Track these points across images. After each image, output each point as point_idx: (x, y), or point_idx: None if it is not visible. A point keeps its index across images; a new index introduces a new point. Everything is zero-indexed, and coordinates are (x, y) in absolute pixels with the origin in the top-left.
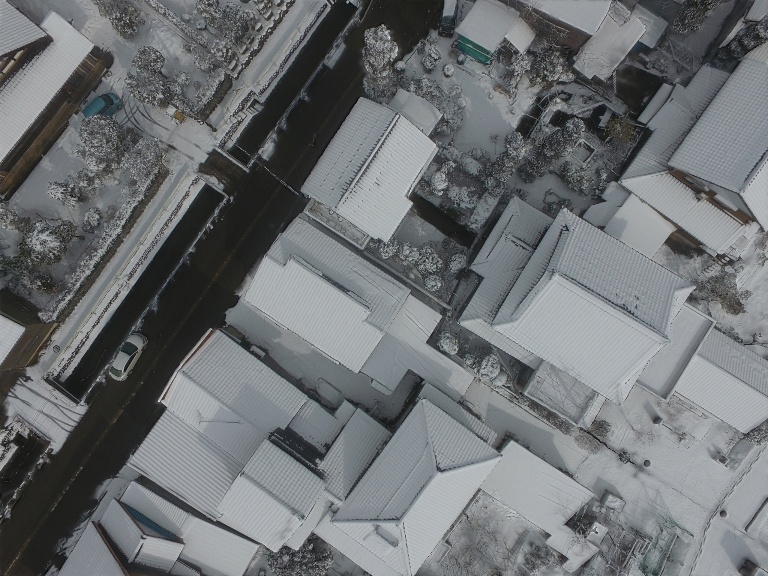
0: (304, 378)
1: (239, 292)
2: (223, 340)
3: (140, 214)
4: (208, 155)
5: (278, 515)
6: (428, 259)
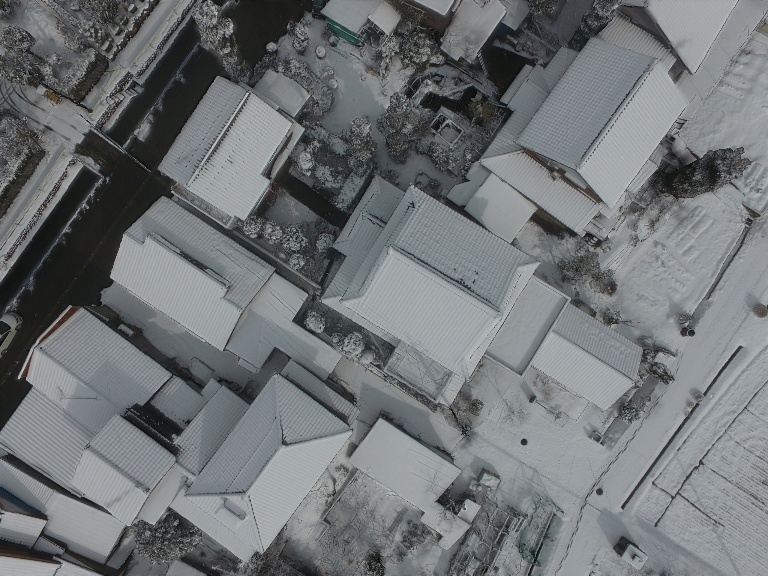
0: (178, 357)
1: None
2: (87, 318)
3: (16, 194)
4: (84, 136)
5: (125, 488)
6: (292, 238)
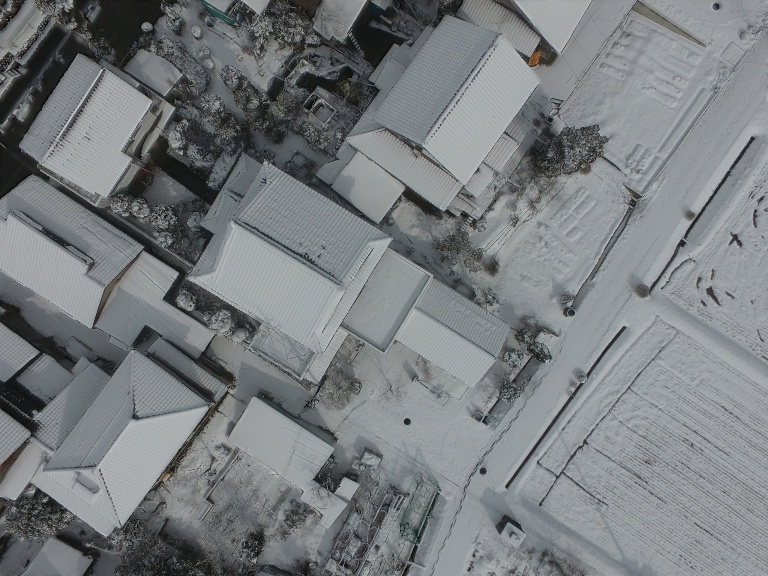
0: (55, 336)
1: None
2: None
3: None
4: None
5: None
6: (160, 216)
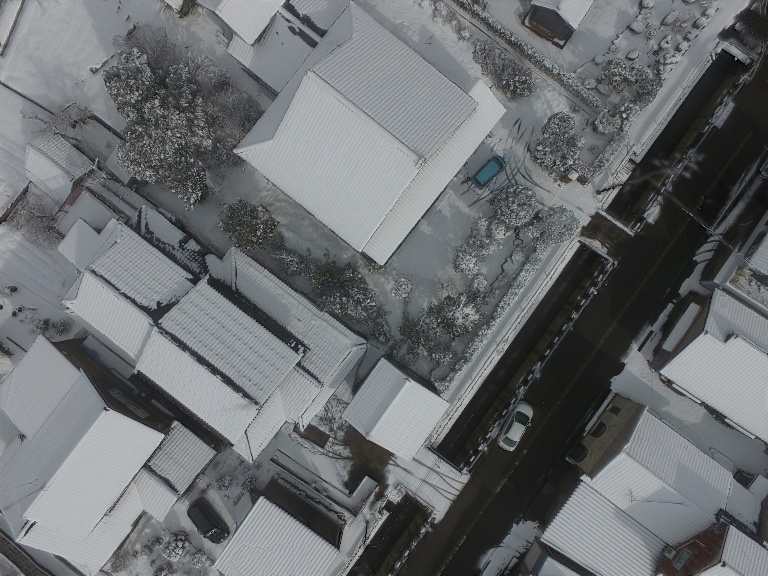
0: None
1: (625, 359)
2: (646, 416)
3: None
4: (591, 218)
5: None
6: None
